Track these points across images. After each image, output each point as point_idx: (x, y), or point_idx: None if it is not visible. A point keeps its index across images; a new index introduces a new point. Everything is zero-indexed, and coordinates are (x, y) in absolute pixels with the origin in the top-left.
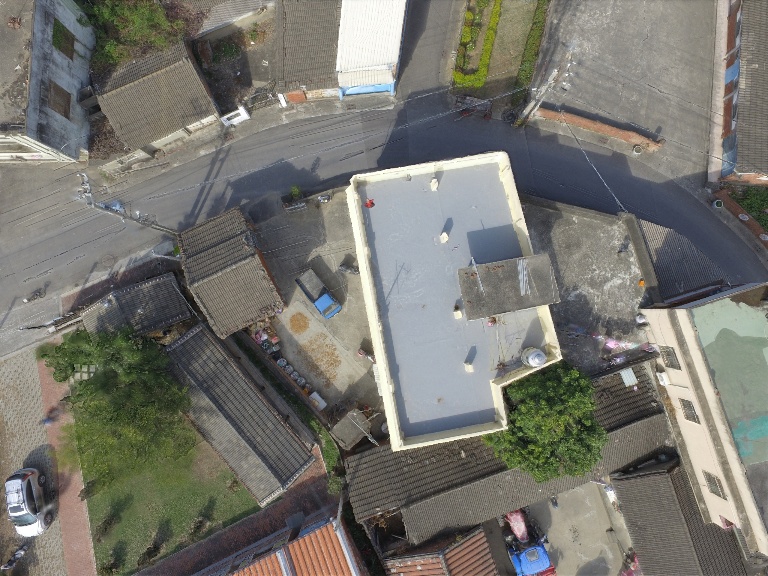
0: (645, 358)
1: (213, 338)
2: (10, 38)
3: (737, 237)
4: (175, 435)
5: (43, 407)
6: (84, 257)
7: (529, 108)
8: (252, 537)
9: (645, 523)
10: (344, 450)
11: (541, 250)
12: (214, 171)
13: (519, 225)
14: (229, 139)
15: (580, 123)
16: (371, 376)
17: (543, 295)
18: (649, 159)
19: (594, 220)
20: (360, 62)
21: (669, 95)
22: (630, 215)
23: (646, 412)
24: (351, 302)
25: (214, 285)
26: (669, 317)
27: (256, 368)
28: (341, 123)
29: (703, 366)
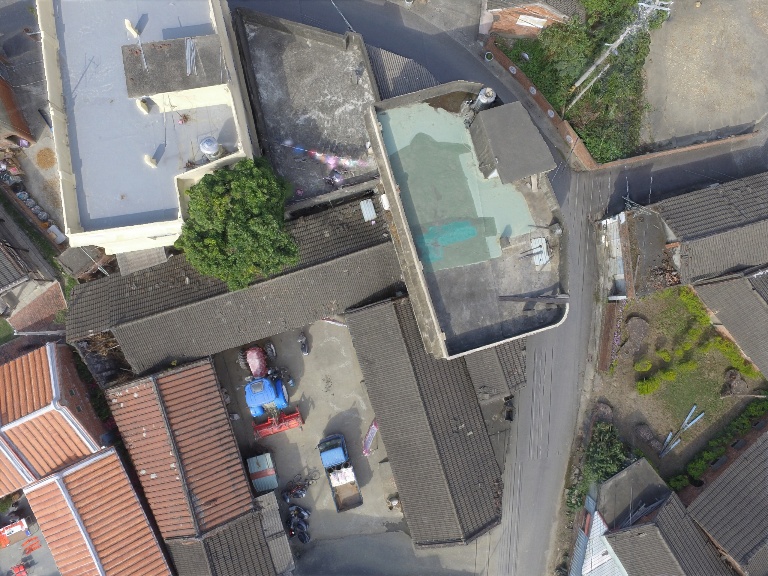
0: None
1: None
2: None
3: (509, 92)
4: None
5: None
6: None
7: None
8: None
9: (374, 357)
10: None
11: (271, 72)
12: None
13: None
14: None
15: None
16: None
17: (211, 76)
18: (422, 10)
19: (328, 45)
20: None
21: None
22: (357, 35)
23: (376, 242)
24: None
25: None
26: (364, 119)
27: None
28: None
29: None
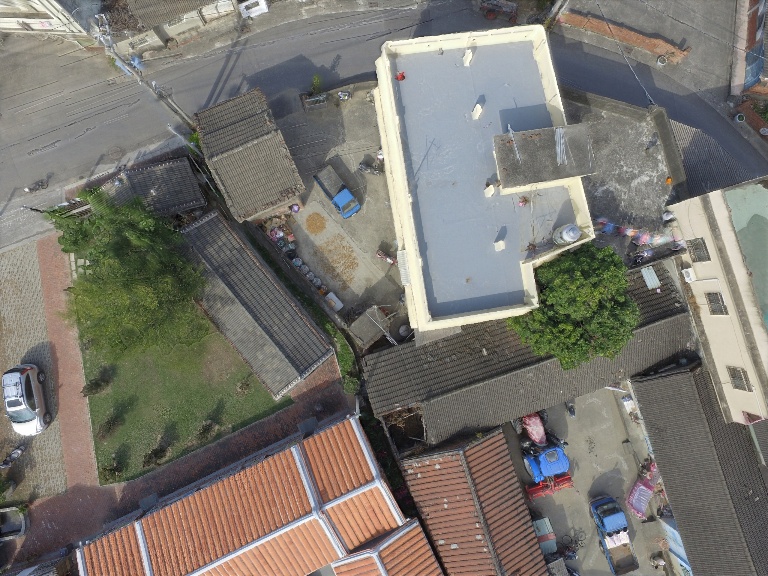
0: (671, 255)
1: (229, 225)
2: None
3: (757, 153)
4: (189, 317)
5: (43, 303)
6: (90, 148)
7: (558, 3)
8: (263, 442)
9: (666, 425)
10: (359, 355)
11: None
12: (229, 64)
13: (553, 102)
14: (246, 32)
15: (605, 31)
16: (389, 280)
17: (580, 165)
18: (673, 71)
19: (623, 116)
20: None
21: (694, 7)
22: (660, 109)
23: (670, 312)
24: (370, 204)
25: (233, 161)
26: (702, 201)
27: (270, 268)
28: None
29: (736, 247)
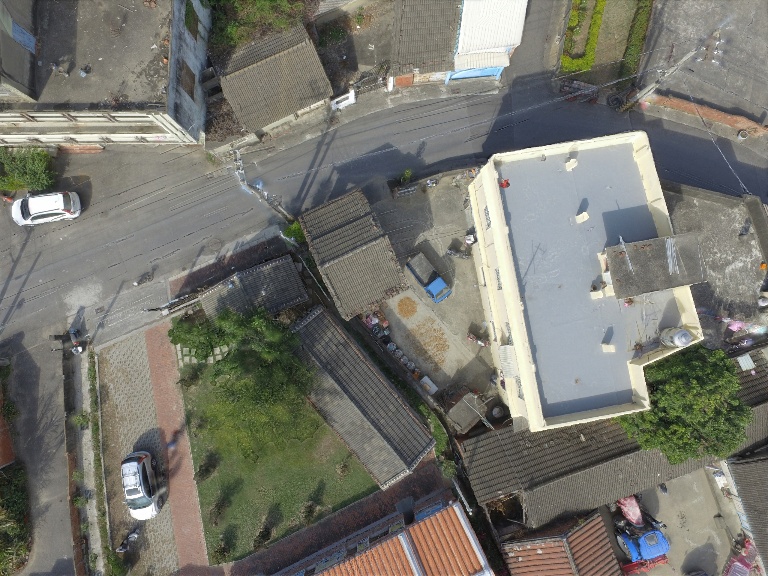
0: None
1: (333, 320)
2: (146, 17)
3: None
4: (304, 416)
5: (152, 391)
6: (191, 241)
7: (645, 91)
8: (362, 521)
9: (765, 507)
10: (452, 435)
11: None
12: (320, 155)
13: (657, 205)
14: (335, 123)
15: (685, 108)
16: (479, 361)
17: (691, 274)
18: (754, 144)
19: (715, 203)
20: (482, 44)
21: None
22: (755, 197)
23: (767, 396)
24: (458, 286)
25: (343, 266)
26: None
27: (365, 352)
28: (446, 107)
29: None
